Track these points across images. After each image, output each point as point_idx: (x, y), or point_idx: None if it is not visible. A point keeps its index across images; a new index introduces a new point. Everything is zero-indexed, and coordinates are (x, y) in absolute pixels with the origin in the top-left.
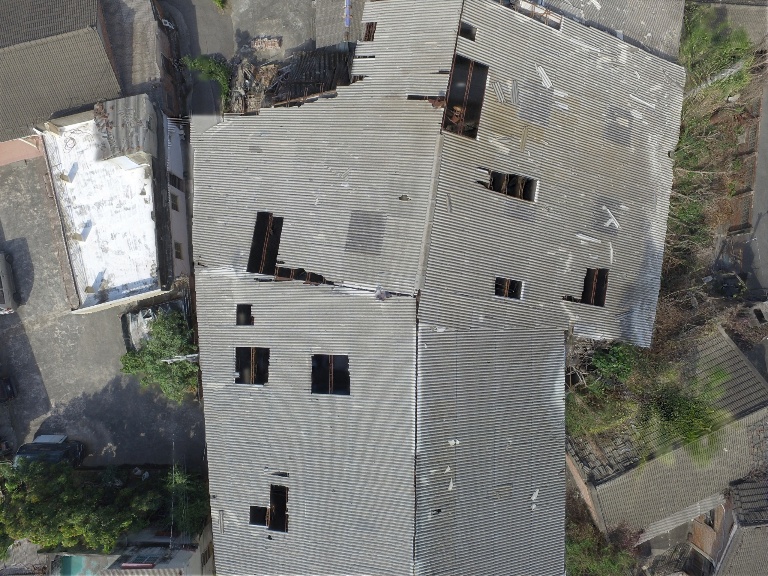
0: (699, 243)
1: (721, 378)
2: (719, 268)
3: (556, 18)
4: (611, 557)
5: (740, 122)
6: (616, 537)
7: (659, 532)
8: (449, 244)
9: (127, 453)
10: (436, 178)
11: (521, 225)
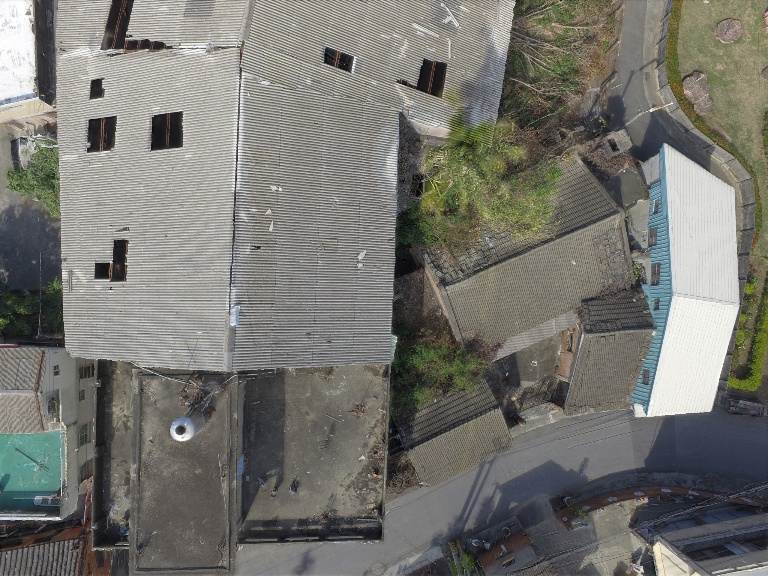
0: (567, 88)
1: (572, 197)
2: (592, 120)
3: None
4: (462, 358)
5: None
6: (472, 347)
7: (516, 348)
8: (275, 5)
9: (19, 279)
10: None
11: (353, 3)
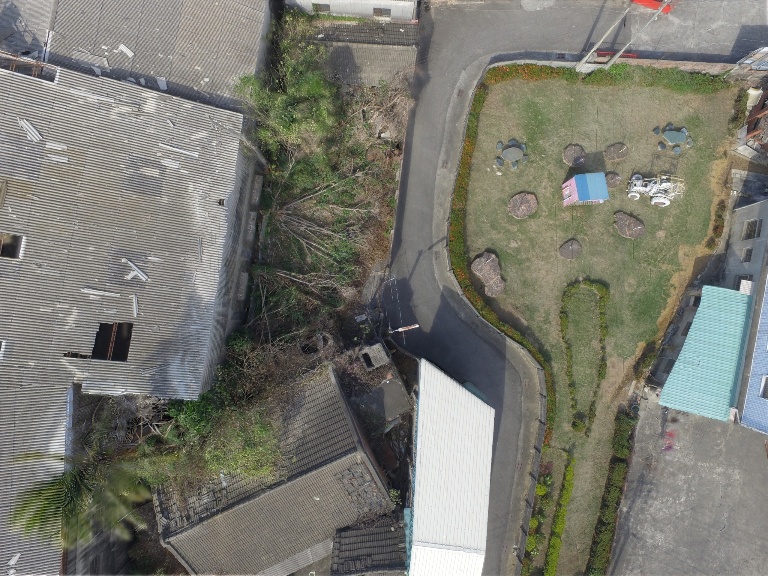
0: (337, 283)
1: (317, 425)
2: (375, 306)
3: (56, 69)
4: None
5: (392, 159)
6: None
7: None
8: None
9: None
10: None
11: None
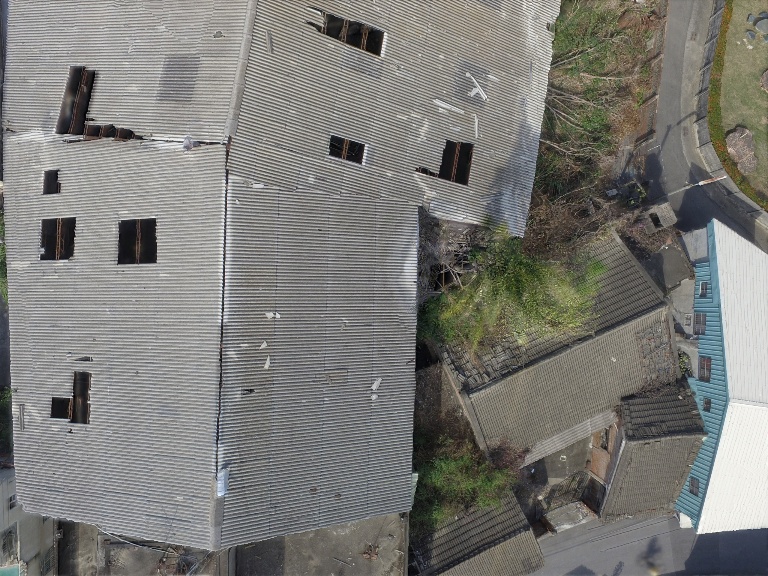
0: (600, 149)
1: (611, 283)
2: (625, 181)
3: None
4: (488, 474)
5: (648, 25)
6: (498, 455)
7: (547, 452)
8: (269, 89)
9: None
10: (252, 10)
11: (363, 80)
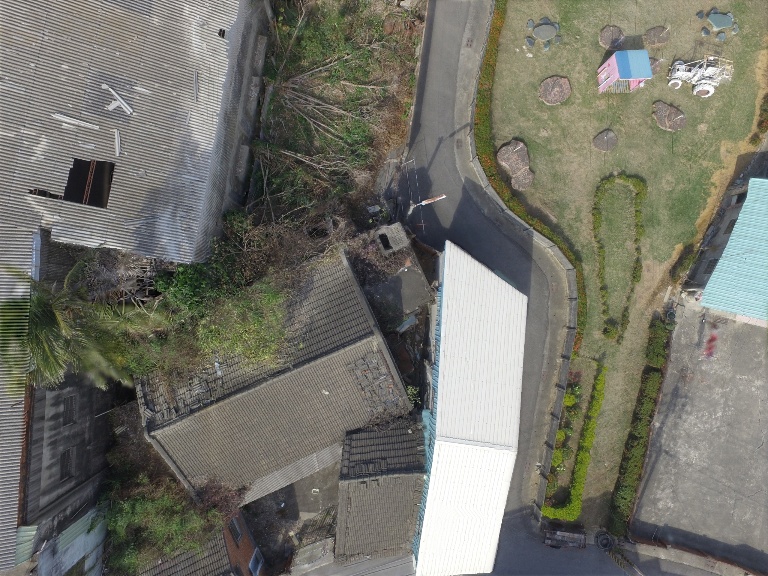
0: (349, 164)
1: (327, 310)
2: (390, 197)
3: None
4: (181, 516)
5: (412, 30)
6: (205, 494)
7: (270, 489)
8: None
9: None
10: None
11: None
